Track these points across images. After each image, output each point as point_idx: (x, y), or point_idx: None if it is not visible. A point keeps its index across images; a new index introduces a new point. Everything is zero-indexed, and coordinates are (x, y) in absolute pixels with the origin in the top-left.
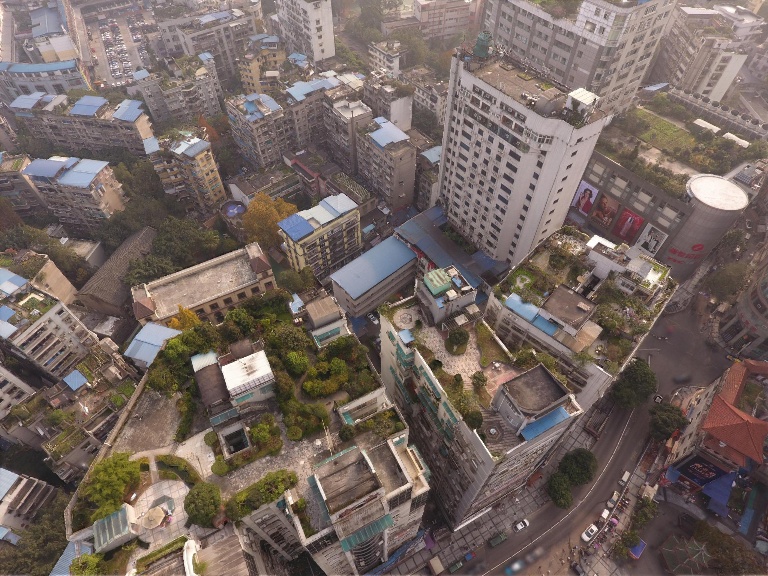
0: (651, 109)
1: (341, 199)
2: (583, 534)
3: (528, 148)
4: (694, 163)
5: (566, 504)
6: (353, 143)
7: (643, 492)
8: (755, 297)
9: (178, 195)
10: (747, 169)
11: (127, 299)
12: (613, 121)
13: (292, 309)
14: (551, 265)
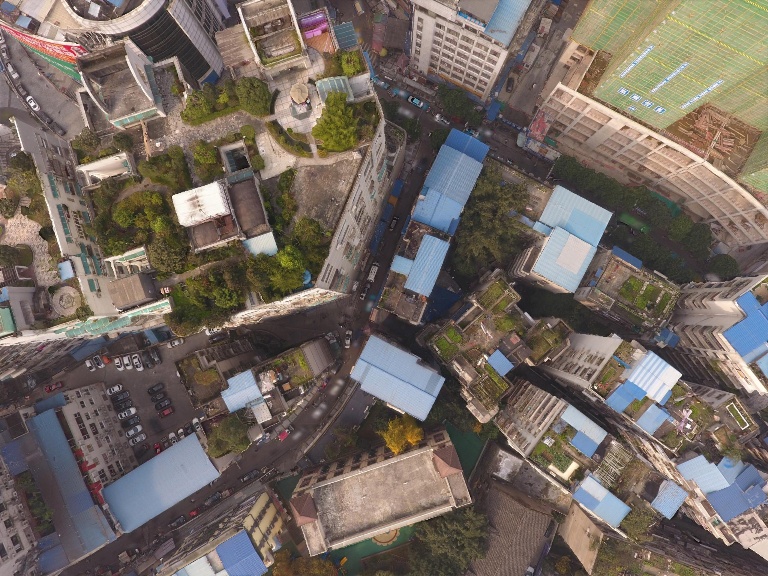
0: None
1: None
2: None
3: None
4: None
5: None
6: None
7: None
8: None
9: None
10: None
11: (486, 499)
12: None
13: (236, 388)
14: None
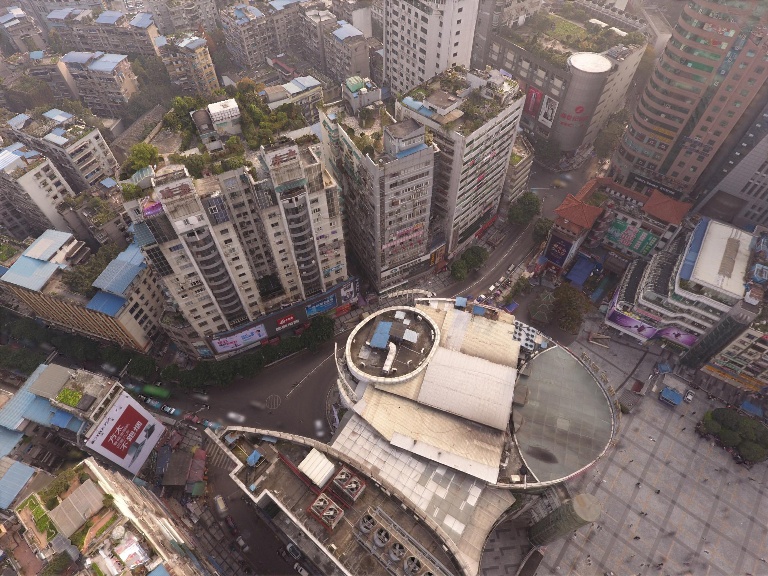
0: (560, 15)
1: (308, 79)
2: (474, 300)
3: (432, 11)
4: (582, 48)
5: (462, 277)
6: (322, 46)
7: (521, 274)
8: (620, 145)
9: (182, 87)
10: (616, 47)
11: None
12: (526, 22)
13: None
14: (441, 86)
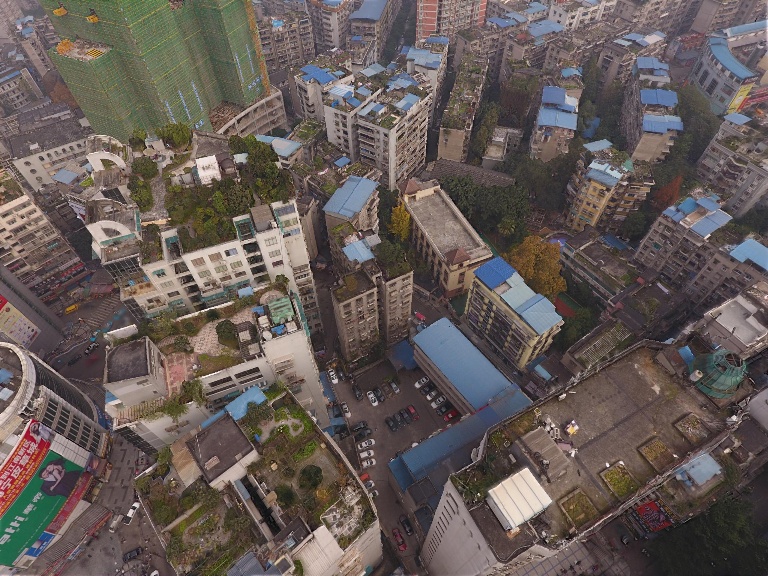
0: None
1: (549, 316)
2: (157, 572)
3: None
4: None
5: None
6: None
7: None
8: None
9: None
10: None
11: None
12: None
13: (356, 254)
14: None
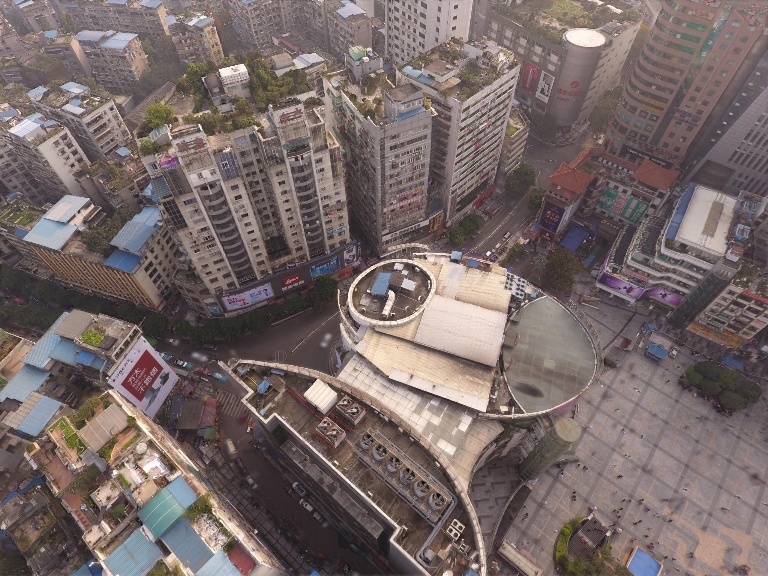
0: None
1: (313, 56)
2: None
3: None
4: (578, 25)
5: (459, 242)
6: (326, 25)
7: (516, 241)
8: (613, 118)
9: None
10: (610, 23)
11: None
12: (525, 0)
13: None
14: (440, 57)
